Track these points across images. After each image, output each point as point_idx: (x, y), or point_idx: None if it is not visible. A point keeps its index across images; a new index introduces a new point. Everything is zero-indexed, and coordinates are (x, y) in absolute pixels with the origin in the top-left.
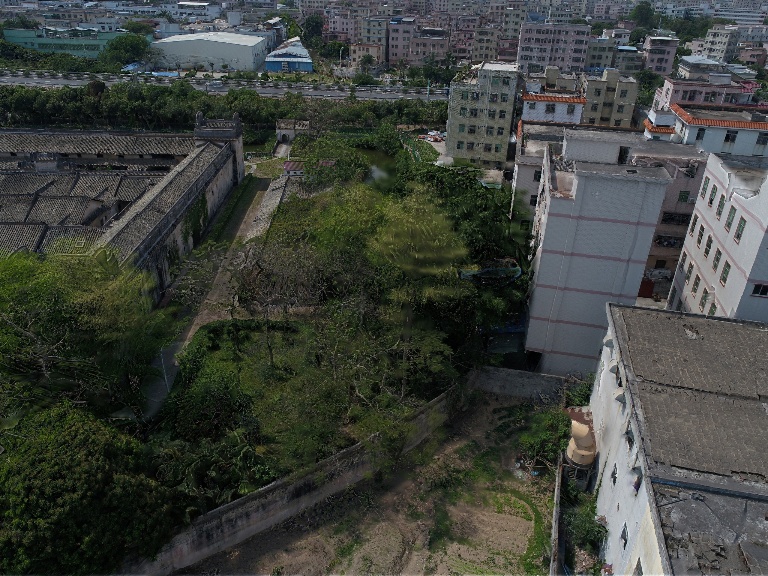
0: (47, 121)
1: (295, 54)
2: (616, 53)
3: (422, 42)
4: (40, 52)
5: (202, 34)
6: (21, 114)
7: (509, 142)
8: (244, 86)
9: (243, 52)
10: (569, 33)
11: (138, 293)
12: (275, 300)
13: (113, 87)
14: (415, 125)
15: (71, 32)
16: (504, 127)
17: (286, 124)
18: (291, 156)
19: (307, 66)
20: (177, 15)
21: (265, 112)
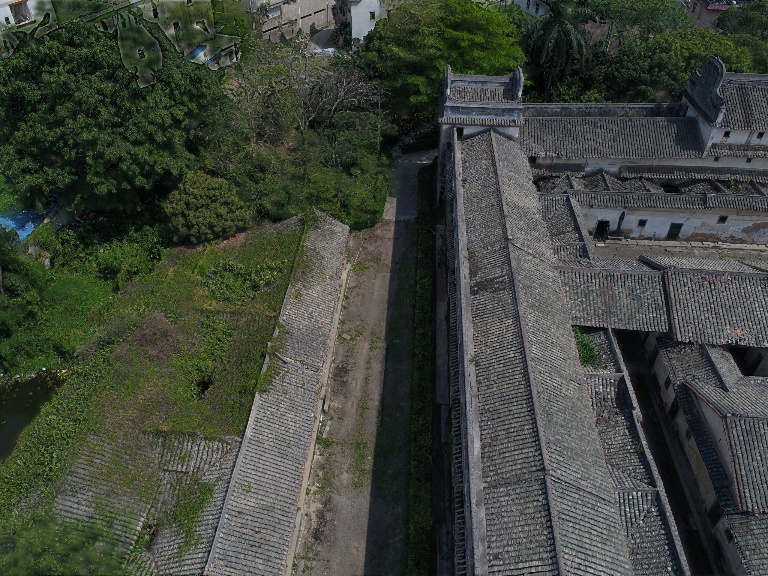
0: None
1: None
2: None
3: None
4: None
5: None
6: None
7: None
8: None
9: None
10: None
11: None
12: None
13: None
14: None
15: None
16: None
17: None
18: None
19: None
20: None
21: None
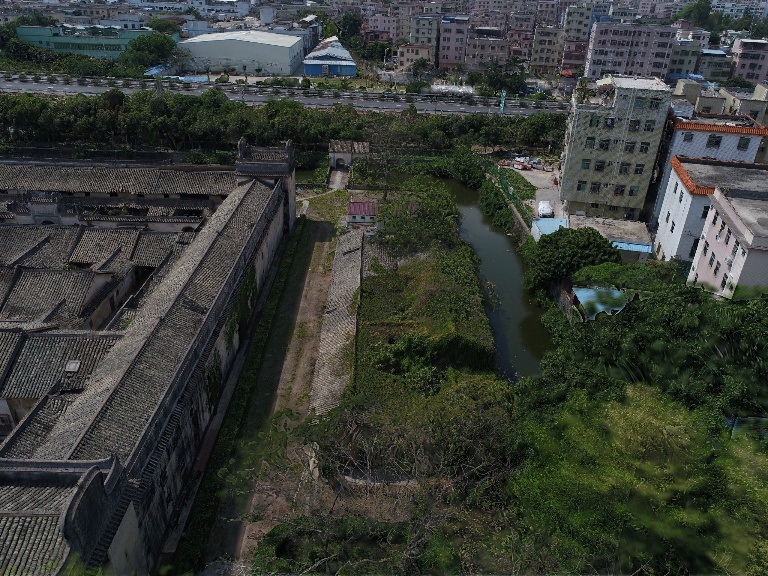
0: (55, 138)
1: (336, 56)
2: (700, 57)
3: (480, 44)
4: (56, 52)
5: (233, 33)
6: (25, 129)
7: (649, 183)
8: (284, 95)
9: (279, 54)
10: (651, 35)
11: (161, 479)
12: (379, 474)
13: (134, 96)
14: (494, 147)
15: (91, 30)
16: (645, 164)
17: (341, 146)
18: (350, 188)
19: (350, 70)
20: (205, 12)
21: (314, 130)
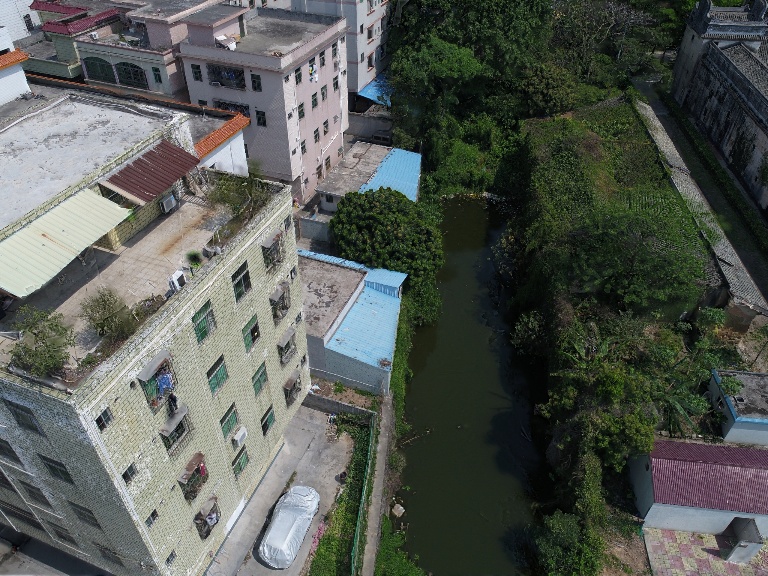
0: None
1: None
2: None
3: None
4: None
5: None
6: None
7: None
8: None
9: None
10: None
11: (711, 92)
12: None
13: None
14: None
15: None
16: None
17: None
18: None
19: None
20: None
21: None
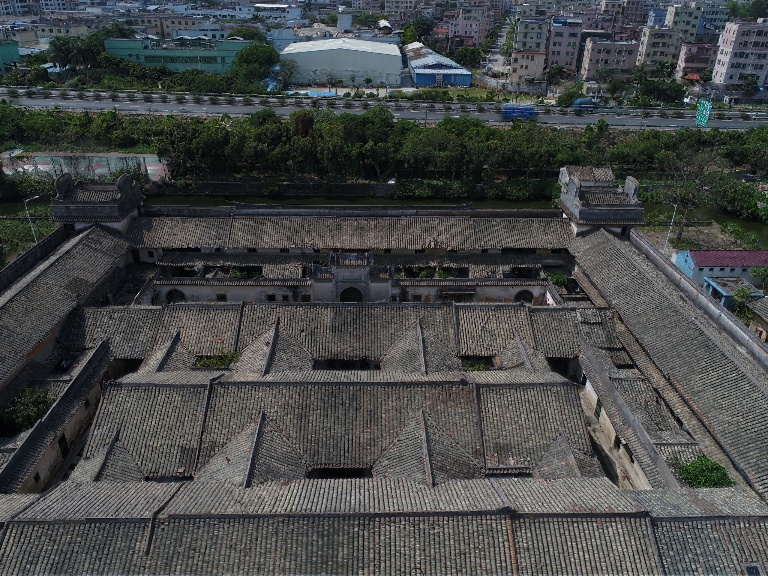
0: (231, 168)
1: (448, 64)
2: None
3: (605, 48)
4: (149, 67)
5: (327, 41)
6: (193, 159)
7: None
8: (439, 110)
9: (390, 63)
10: None
11: None
12: None
13: None
14: (732, 168)
15: (178, 41)
16: None
17: (581, 173)
18: None
19: (464, 79)
20: (270, 19)
21: None
